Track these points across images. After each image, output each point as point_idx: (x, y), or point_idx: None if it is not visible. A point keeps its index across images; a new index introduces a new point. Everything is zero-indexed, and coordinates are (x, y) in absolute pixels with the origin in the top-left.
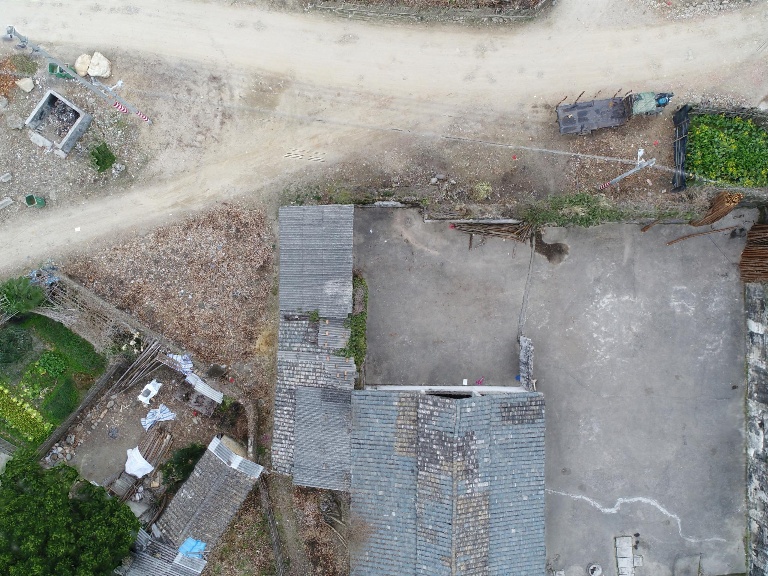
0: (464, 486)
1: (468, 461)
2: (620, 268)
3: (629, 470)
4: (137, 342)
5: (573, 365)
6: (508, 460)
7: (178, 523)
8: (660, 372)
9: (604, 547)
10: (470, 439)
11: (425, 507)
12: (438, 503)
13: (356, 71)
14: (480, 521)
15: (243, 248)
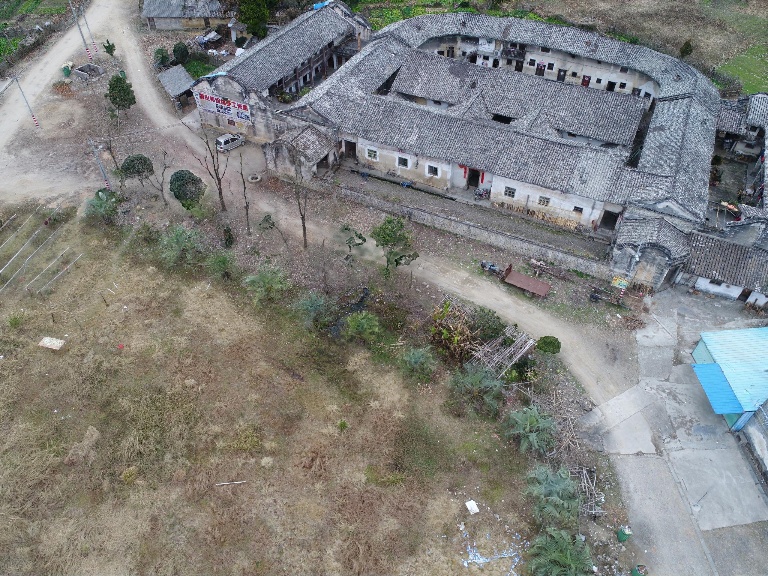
0: None
1: None
2: None
3: None
4: None
5: None
6: None
7: None
8: None
9: None
10: None
11: None
12: None
13: (96, 23)
14: None
15: None
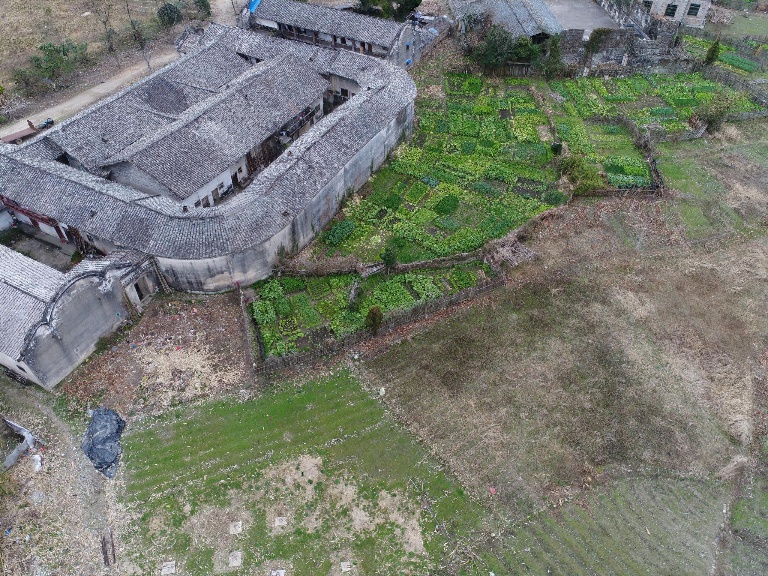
0: None
1: None
2: (556, 2)
3: None
4: None
5: None
6: None
7: None
8: None
9: None
10: None
11: (512, 3)
12: None
13: None
14: None
15: (431, 8)
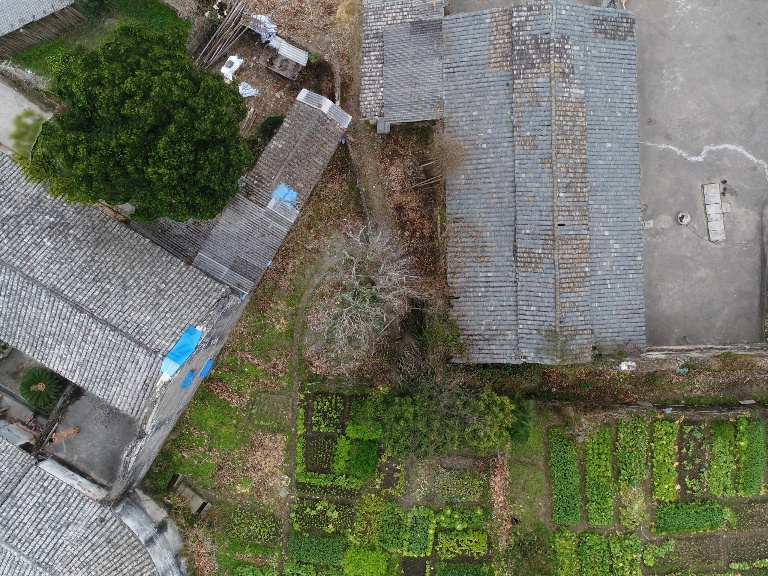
0: (561, 89)
1: (564, 64)
2: None
3: (714, 118)
4: (220, 8)
5: (655, 16)
6: (602, 74)
7: (270, 171)
8: (742, 19)
9: (692, 195)
10: (566, 42)
11: (522, 115)
12: (536, 107)
13: None
14: (578, 126)
15: None
